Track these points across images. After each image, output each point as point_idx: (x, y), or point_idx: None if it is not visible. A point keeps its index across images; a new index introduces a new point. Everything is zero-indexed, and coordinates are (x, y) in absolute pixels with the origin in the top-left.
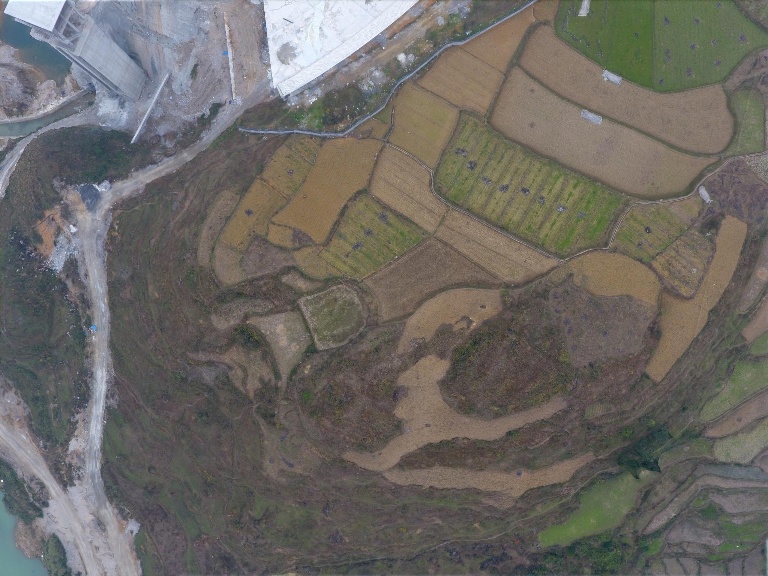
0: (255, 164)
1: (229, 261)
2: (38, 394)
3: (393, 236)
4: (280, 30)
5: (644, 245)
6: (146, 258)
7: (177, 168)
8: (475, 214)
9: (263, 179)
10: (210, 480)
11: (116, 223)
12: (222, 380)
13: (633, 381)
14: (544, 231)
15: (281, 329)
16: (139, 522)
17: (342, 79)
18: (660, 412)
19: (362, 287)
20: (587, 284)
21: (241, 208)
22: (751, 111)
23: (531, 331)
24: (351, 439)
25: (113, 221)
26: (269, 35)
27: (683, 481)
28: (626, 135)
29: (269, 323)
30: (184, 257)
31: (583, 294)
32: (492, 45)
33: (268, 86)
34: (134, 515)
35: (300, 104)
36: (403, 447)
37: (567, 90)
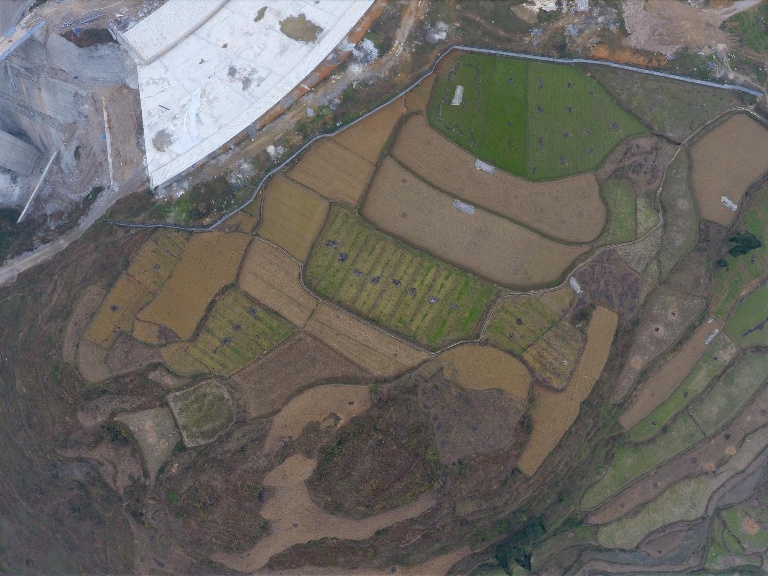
0: (122, 258)
1: (94, 358)
2: None
3: (262, 330)
4: (156, 117)
5: (515, 337)
6: (14, 352)
7: (53, 255)
8: (346, 307)
9: (129, 274)
10: None
11: None
12: (93, 476)
13: (504, 476)
14: (416, 323)
15: (150, 425)
16: None
17: (210, 172)
18: (537, 504)
19: (230, 383)
20: (457, 378)
21: (106, 304)
22: (622, 200)
23: (398, 429)
24: (217, 541)
25: None
26: (145, 122)
27: (569, 568)
28: (498, 225)
29: (137, 419)
30: (49, 353)
31: (452, 389)
32: (363, 136)
33: (144, 173)
34: None
35: (168, 197)
36: (271, 548)
37: (440, 180)
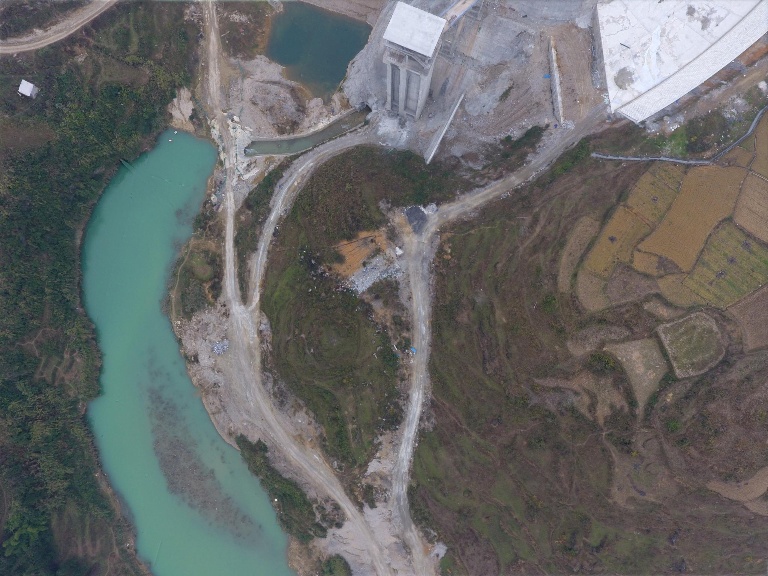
0: (615, 190)
1: (592, 288)
2: (338, 415)
3: (757, 264)
4: (617, 55)
5: None
6: (491, 283)
7: (505, 191)
8: None
9: (627, 206)
10: (541, 506)
11: (448, 246)
12: (565, 406)
13: None
14: None
15: (637, 356)
16: (447, 545)
17: (704, 106)
18: None
19: (727, 315)
20: None
21: (605, 235)
22: None
23: None
24: (720, 469)
25: (443, 244)
26: (606, 60)
27: None
28: None
29: (625, 350)
30: (542, 283)
31: None
32: None
33: (605, 111)
34: (444, 539)
35: (660, 131)
36: None
37: None
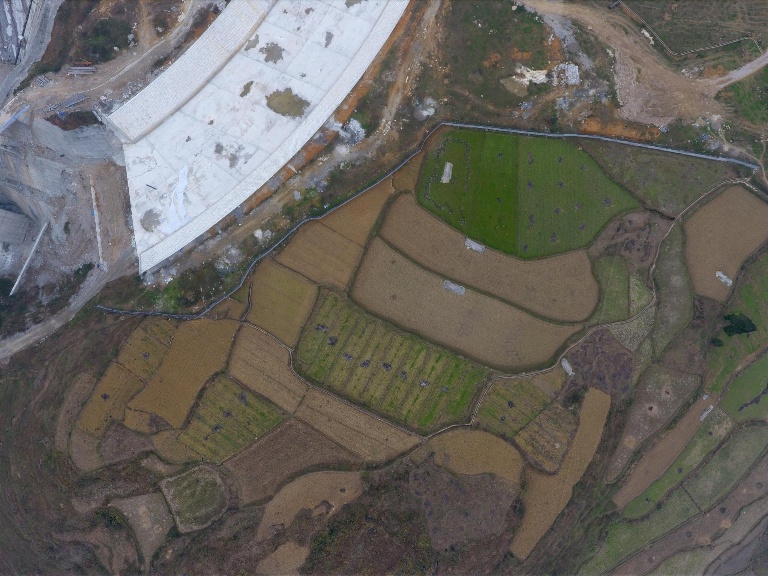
0: (112, 346)
1: (86, 447)
2: None
3: (253, 417)
4: (143, 197)
5: (507, 420)
6: (8, 437)
7: (45, 335)
8: (336, 391)
9: (119, 362)
10: None
11: None
12: (89, 558)
13: (496, 561)
14: (407, 407)
15: (143, 511)
16: None
17: (198, 258)
18: None
19: (222, 470)
20: (449, 463)
21: (97, 393)
22: (615, 278)
23: (389, 517)
24: None
25: None
26: (132, 202)
27: None
28: (489, 305)
29: (131, 505)
30: (42, 441)
31: (444, 474)
32: (351, 218)
33: (132, 254)
34: None
35: (156, 283)
36: None
37: (429, 260)
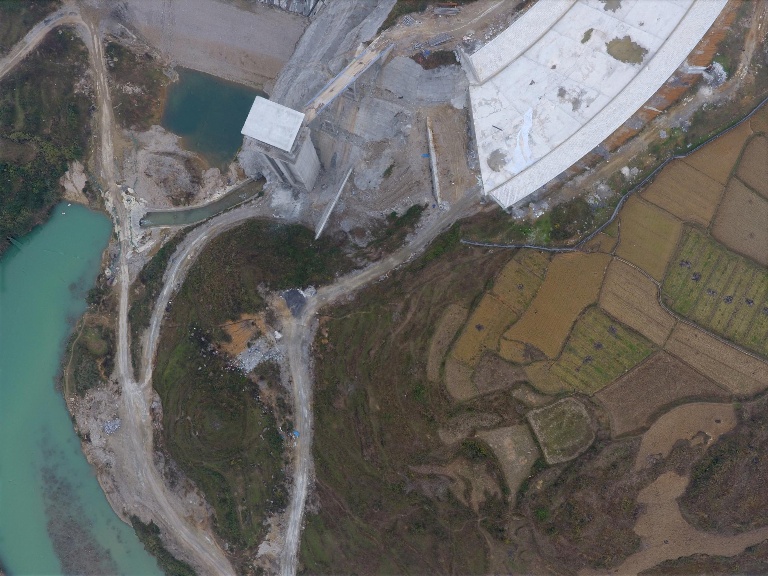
0: (482, 278)
1: (460, 377)
2: (227, 497)
3: (623, 349)
4: (489, 137)
5: None
6: (365, 369)
7: (383, 273)
8: (701, 326)
9: (493, 294)
10: None
11: (326, 330)
12: (442, 492)
13: None
14: None
15: (509, 443)
16: None
17: (568, 193)
18: None
19: (594, 401)
20: None
21: (471, 323)
22: None
23: None
24: (589, 557)
25: (321, 328)
26: (479, 142)
27: None
28: None
29: (496, 437)
30: (412, 372)
31: None
32: (712, 158)
33: (478, 193)
34: None
35: (526, 217)
36: (641, 564)
37: None
